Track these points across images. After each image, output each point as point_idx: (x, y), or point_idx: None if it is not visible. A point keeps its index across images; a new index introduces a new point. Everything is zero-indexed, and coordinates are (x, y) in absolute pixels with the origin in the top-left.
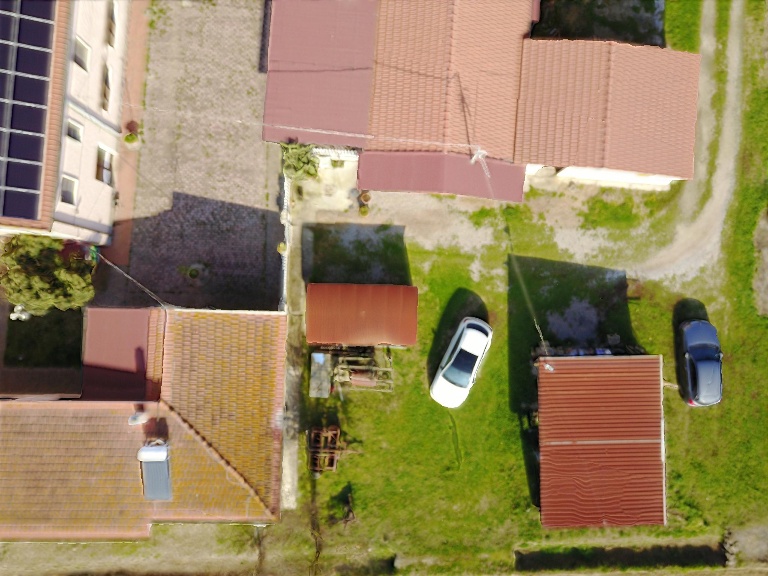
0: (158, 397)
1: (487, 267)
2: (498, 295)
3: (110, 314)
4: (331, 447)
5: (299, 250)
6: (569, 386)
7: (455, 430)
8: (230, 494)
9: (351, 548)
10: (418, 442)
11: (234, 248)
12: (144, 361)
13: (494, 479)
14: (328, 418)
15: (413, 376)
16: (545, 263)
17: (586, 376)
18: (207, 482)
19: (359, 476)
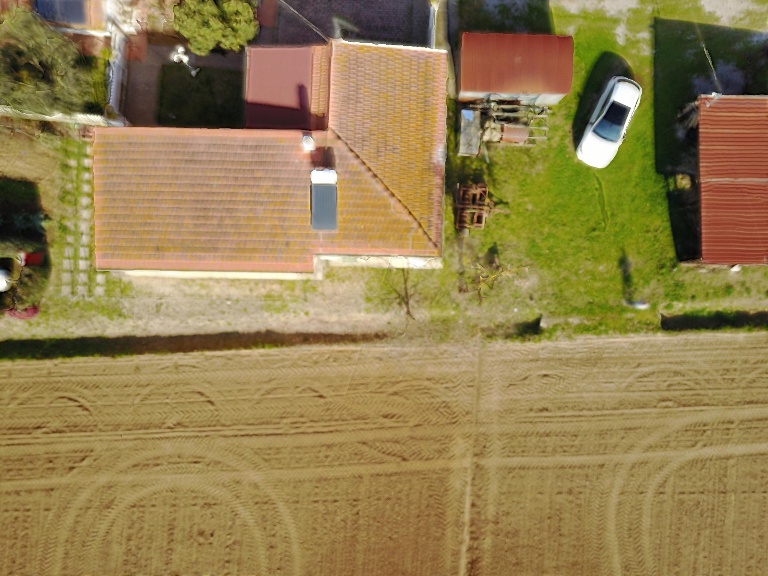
0: (325, 128)
1: (633, 31)
2: (644, 58)
3: (274, 52)
4: (480, 203)
5: (445, 14)
6: (730, 125)
7: (601, 191)
8: (395, 226)
9: (497, 308)
10: (564, 204)
11: (381, 12)
12: (308, 98)
13: (640, 240)
14: (475, 180)
15: (559, 139)
16: (692, 26)
17: (747, 115)
18: (372, 213)
19: (505, 237)
